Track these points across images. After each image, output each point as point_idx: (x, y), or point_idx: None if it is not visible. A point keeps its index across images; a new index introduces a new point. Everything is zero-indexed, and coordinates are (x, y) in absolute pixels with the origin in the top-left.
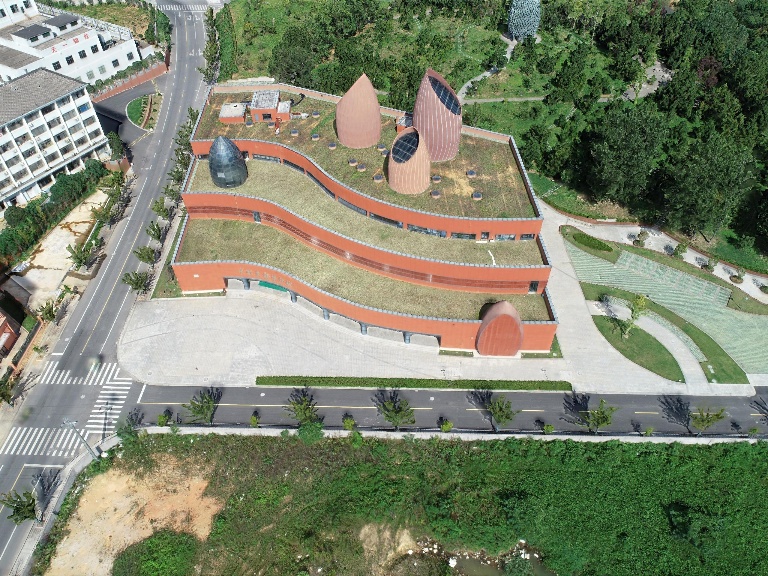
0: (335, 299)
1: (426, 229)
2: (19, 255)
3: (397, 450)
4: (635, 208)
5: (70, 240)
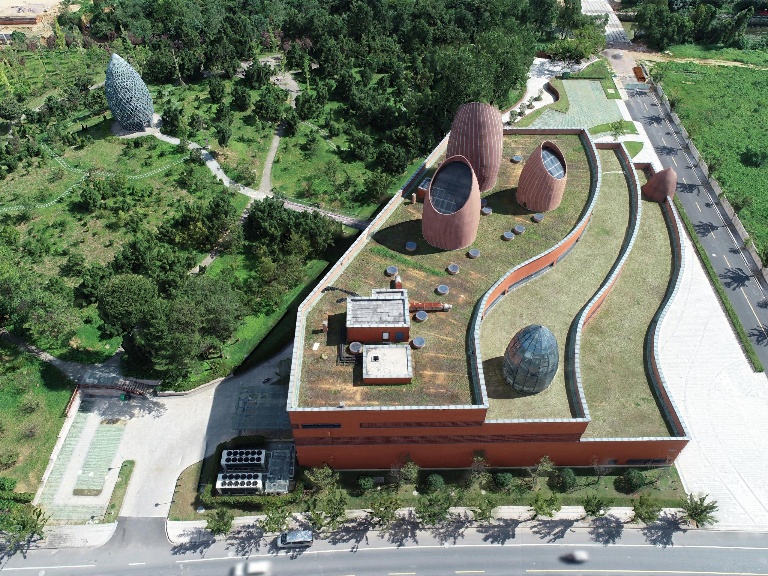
0: None
1: None
2: None
3: None
4: None
5: None
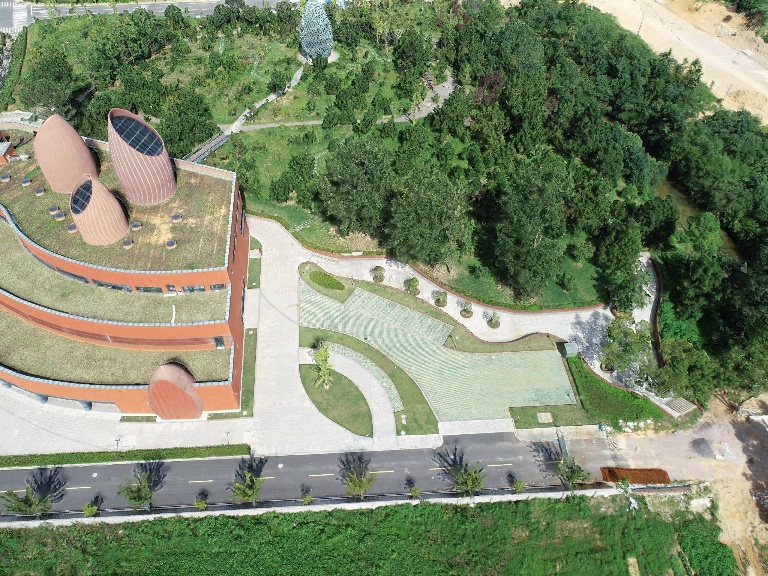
0: None
1: (111, 284)
2: None
3: (33, 541)
4: (386, 239)
5: None
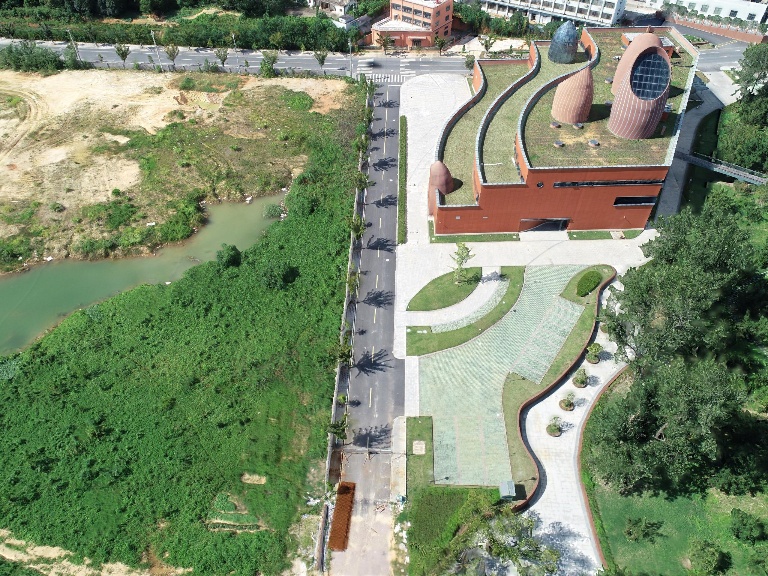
0: None
1: None
2: (494, 34)
3: None
4: None
5: (514, 46)
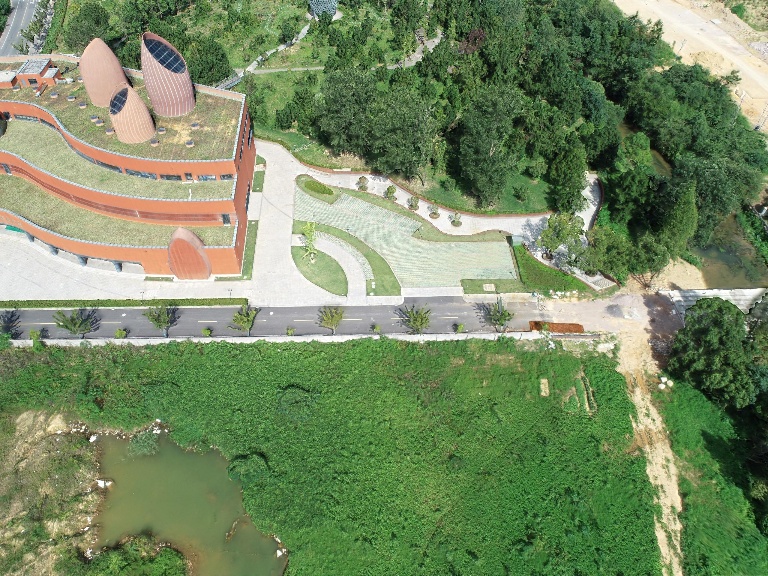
0: (48, 233)
1: None
2: None
3: (75, 355)
4: (372, 159)
5: None
